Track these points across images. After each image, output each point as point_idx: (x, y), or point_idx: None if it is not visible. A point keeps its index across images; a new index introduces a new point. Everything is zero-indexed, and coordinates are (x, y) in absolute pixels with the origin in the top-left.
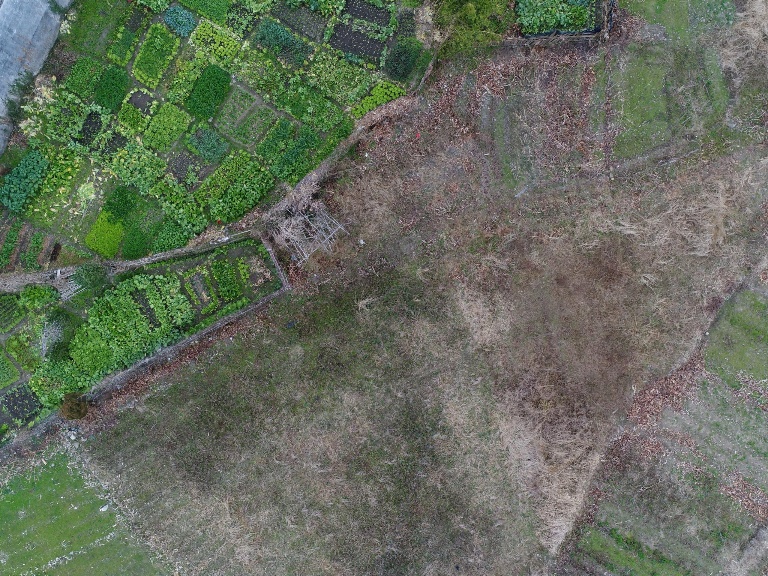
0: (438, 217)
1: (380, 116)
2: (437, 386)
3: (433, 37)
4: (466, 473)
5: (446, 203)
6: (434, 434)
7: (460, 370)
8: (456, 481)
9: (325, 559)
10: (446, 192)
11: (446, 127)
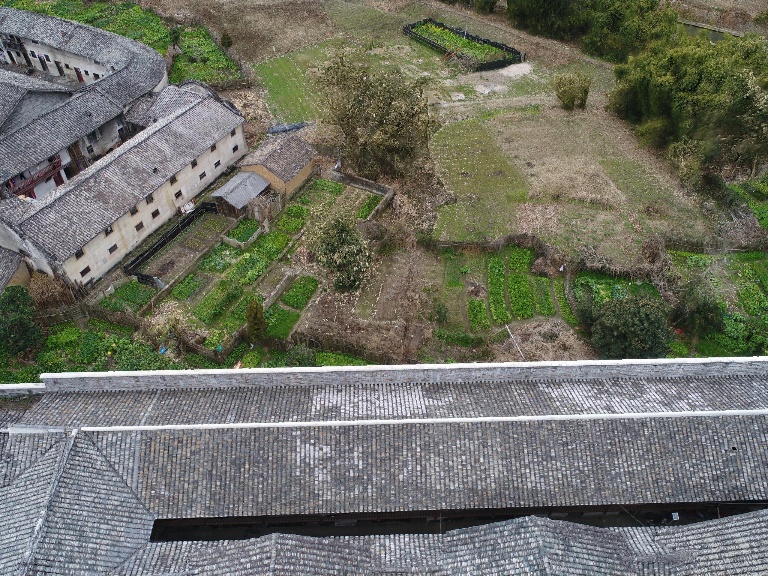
0: (187, 4)
1: (145, 5)
2: (248, 5)
3: None
4: (281, 2)
5: (183, 3)
6: (265, 5)
7: (244, 2)
8: (283, 3)
9: None
10: (179, 3)
11: (155, 2)
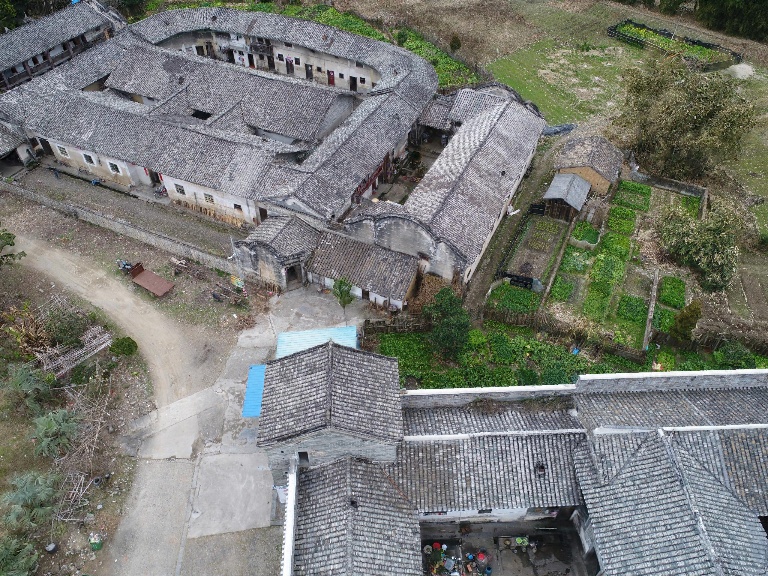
0: (377, 6)
1: (341, 7)
2: None
3: (314, 1)
4: None
5: (372, 5)
6: (455, 7)
7: (431, 4)
8: None
9: (506, 23)
10: (368, 5)
11: (345, 4)
